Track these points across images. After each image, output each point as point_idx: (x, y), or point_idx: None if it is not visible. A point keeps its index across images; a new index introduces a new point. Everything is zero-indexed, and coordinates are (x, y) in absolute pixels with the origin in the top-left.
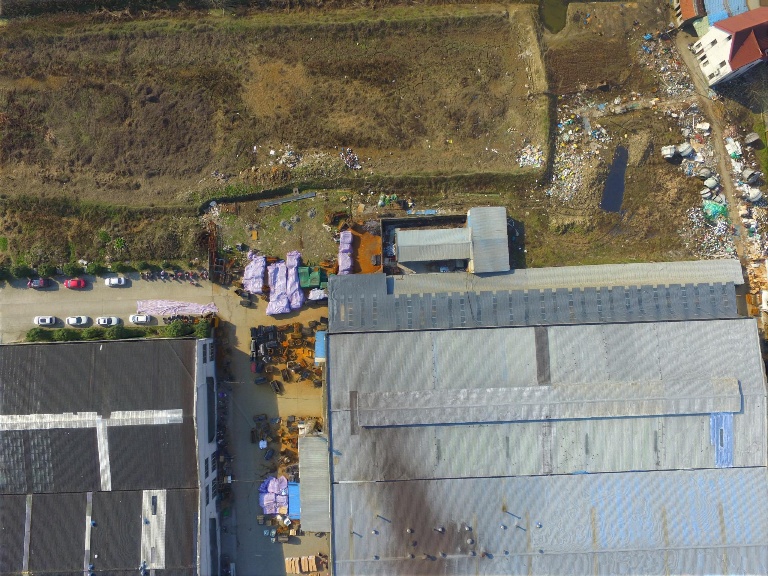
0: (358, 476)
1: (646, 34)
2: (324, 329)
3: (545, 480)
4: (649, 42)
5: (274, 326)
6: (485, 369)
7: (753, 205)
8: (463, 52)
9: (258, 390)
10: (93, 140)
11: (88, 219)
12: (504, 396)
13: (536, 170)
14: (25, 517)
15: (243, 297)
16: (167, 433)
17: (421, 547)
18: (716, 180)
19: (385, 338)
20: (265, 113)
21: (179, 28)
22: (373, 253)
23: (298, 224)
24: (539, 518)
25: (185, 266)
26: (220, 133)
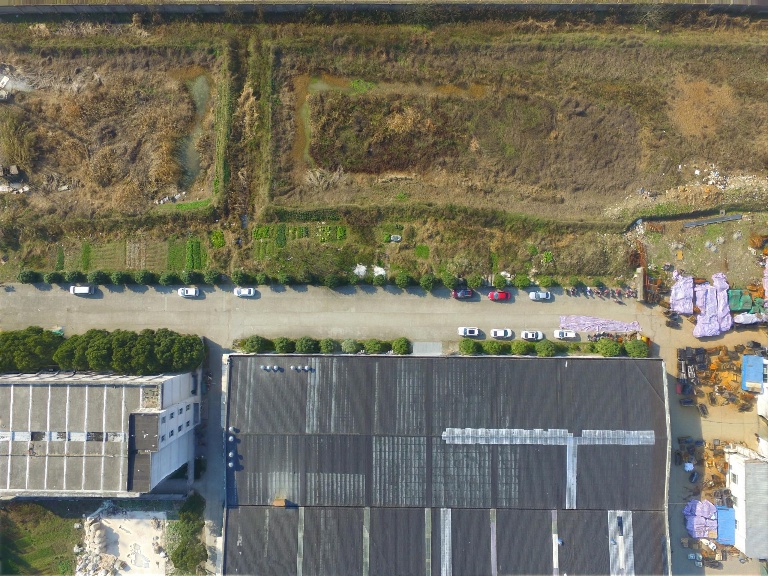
0: None
1: None
2: (752, 353)
3: None
4: None
5: None
6: None
7: None
8: None
9: (681, 412)
10: (517, 151)
11: (511, 231)
12: None
13: None
14: (490, 532)
15: (673, 317)
16: (638, 454)
17: None
18: None
19: None
20: (691, 132)
21: (609, 42)
22: None
23: (723, 246)
24: None
25: (609, 283)
26: (645, 150)
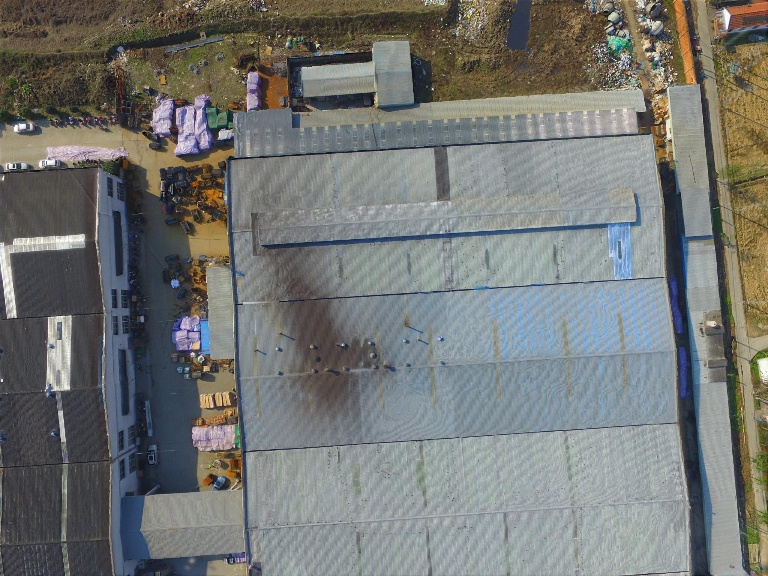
0: (262, 297)
1: None
2: None
3: (447, 296)
4: None
5: (184, 167)
6: (385, 188)
7: (657, 39)
8: None
9: (170, 232)
10: None
11: None
12: (403, 211)
13: (441, 8)
14: None
15: (152, 139)
16: (70, 258)
17: (325, 363)
18: (618, 13)
19: (286, 161)
20: None
21: None
22: (281, 95)
23: (206, 68)
24: (441, 332)
25: (94, 112)
26: None
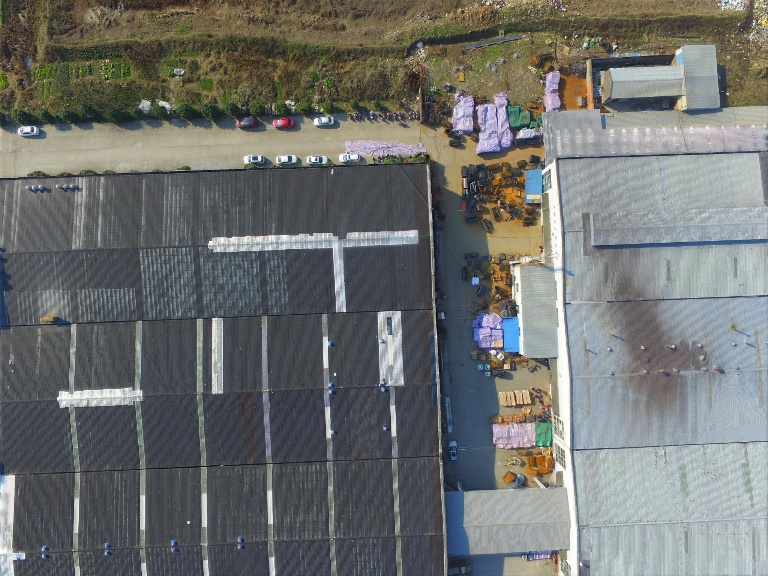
0: (590, 297)
1: None
2: (533, 168)
3: None
4: None
5: None
6: (713, 192)
7: None
8: None
9: (468, 229)
10: None
11: (294, 60)
12: (735, 216)
13: (739, 13)
14: (261, 338)
15: (454, 136)
16: (403, 254)
17: (654, 363)
18: None
19: (614, 162)
20: None
21: None
22: (579, 95)
23: (504, 66)
24: (767, 336)
25: (392, 107)
26: None
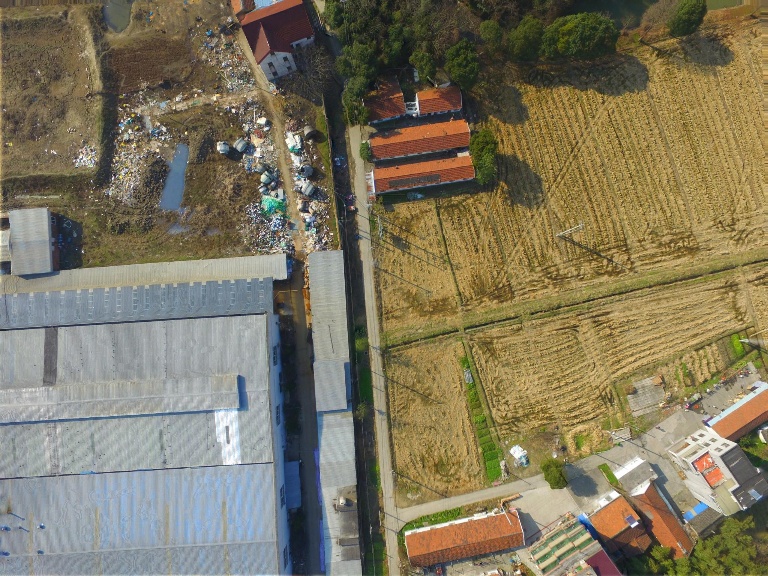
0: None
1: (208, 30)
2: None
3: (52, 481)
4: (211, 38)
5: None
6: None
7: (311, 199)
8: (25, 54)
9: None
10: None
11: None
12: (3, 398)
13: (88, 170)
14: None
15: None
16: None
17: None
18: (266, 175)
19: None
20: None
21: None
22: None
23: None
24: (43, 519)
25: None
26: None
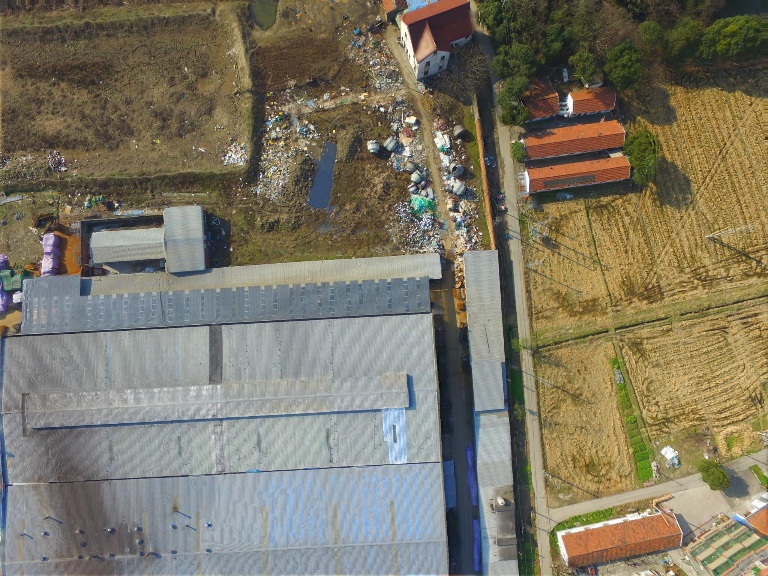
0: (32, 478)
1: (355, 28)
2: None
3: (218, 479)
4: (359, 36)
5: None
6: (157, 369)
7: (461, 198)
8: (171, 51)
9: None
10: None
11: None
12: (171, 396)
13: (239, 168)
14: None
15: None
16: None
17: (91, 548)
18: (418, 174)
19: (60, 340)
20: None
21: None
22: (79, 255)
23: (5, 227)
24: (209, 517)
25: None
26: None
